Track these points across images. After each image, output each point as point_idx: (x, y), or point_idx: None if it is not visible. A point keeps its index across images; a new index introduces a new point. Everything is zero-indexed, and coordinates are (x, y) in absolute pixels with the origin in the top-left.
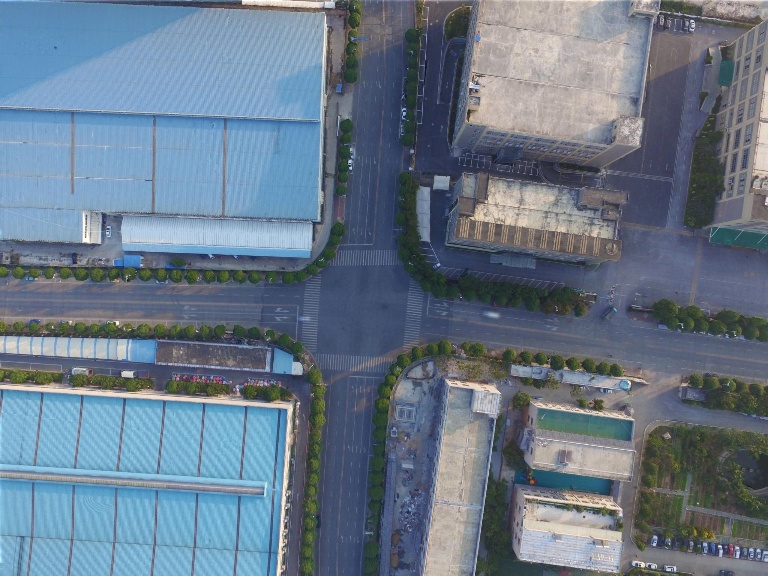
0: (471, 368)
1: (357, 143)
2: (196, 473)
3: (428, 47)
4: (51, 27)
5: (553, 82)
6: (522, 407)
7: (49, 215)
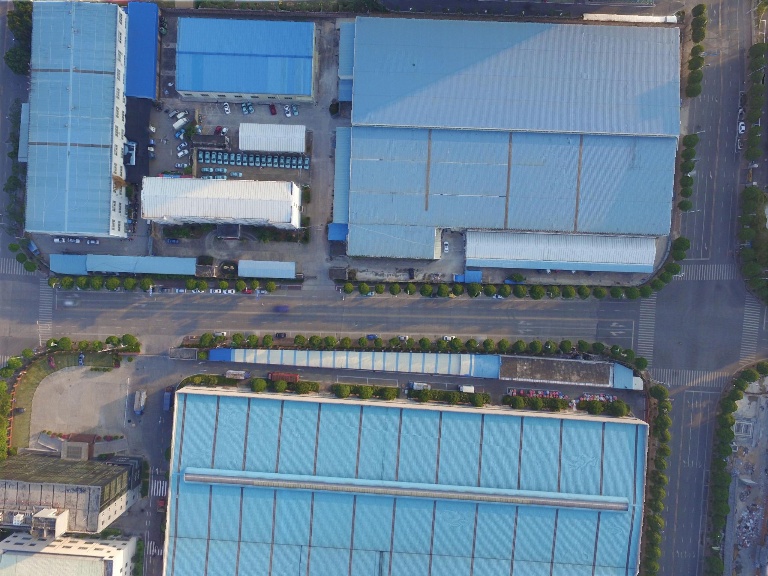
0: None
1: None
2: (556, 489)
3: None
4: (408, 44)
5: None
6: None
7: (402, 231)
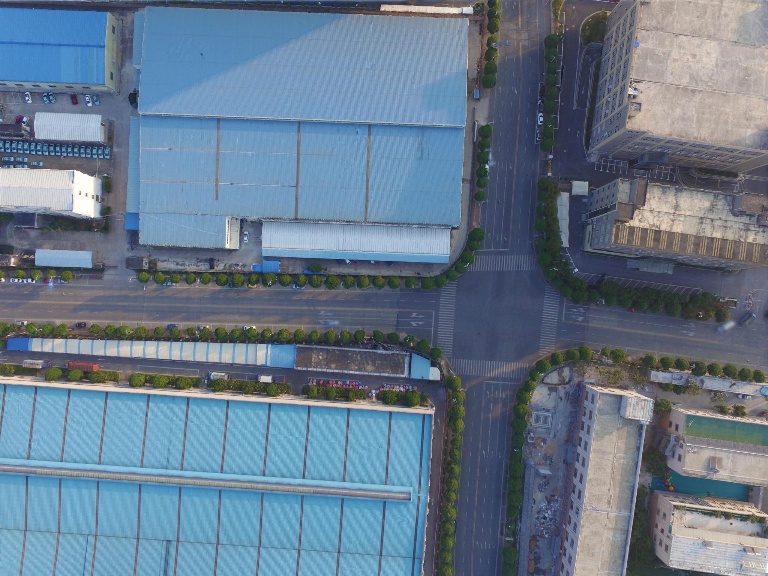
0: (612, 374)
1: (493, 148)
2: (342, 478)
3: (564, 52)
4: (197, 34)
5: (711, 88)
6: (664, 413)
7: (193, 221)
